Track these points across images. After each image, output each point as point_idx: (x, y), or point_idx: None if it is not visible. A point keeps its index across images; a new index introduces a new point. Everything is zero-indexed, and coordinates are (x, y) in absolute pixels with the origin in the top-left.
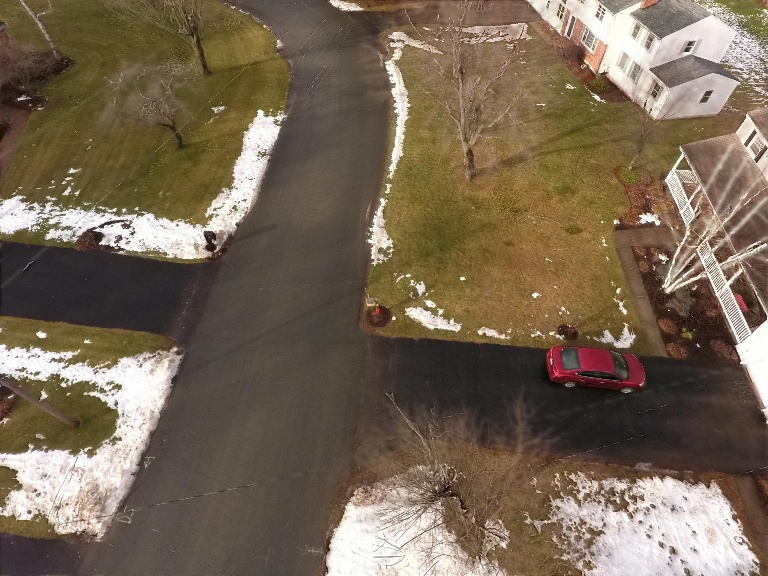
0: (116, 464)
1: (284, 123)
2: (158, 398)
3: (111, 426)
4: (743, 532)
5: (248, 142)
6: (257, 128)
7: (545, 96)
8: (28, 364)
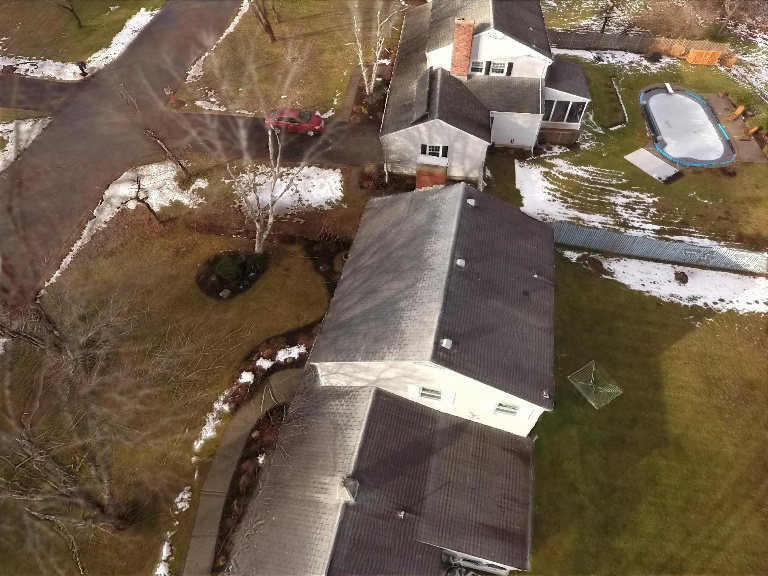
0: (2, 158)
1: (157, 15)
2: (32, 135)
3: (3, 146)
4: (342, 186)
5: (128, 25)
6: (137, 17)
7: (361, 1)
8: None
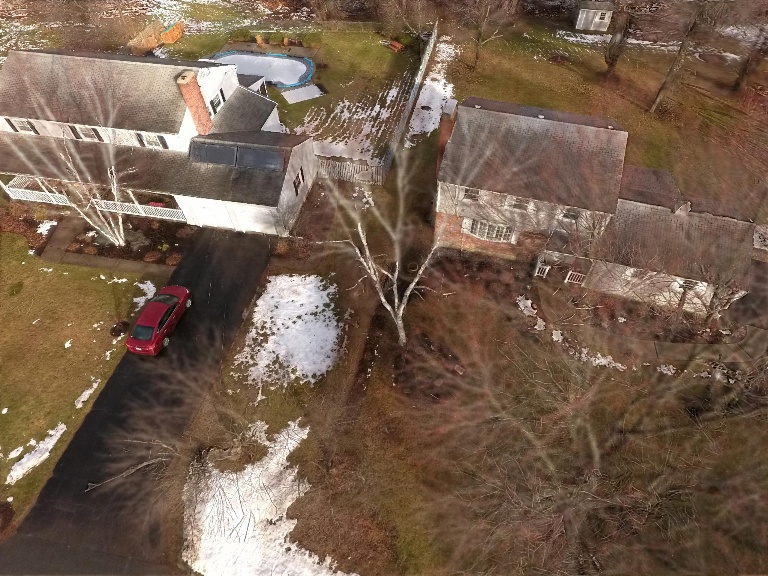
0: None
1: None
2: None
3: None
4: (300, 275)
5: None
6: None
7: None
8: None
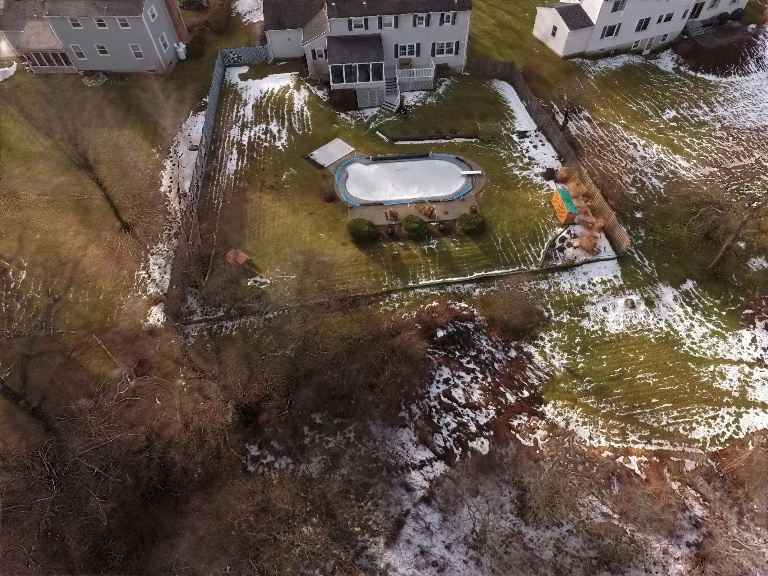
0: None
1: None
2: None
3: None
4: (262, 20)
5: None
6: None
7: None
8: None
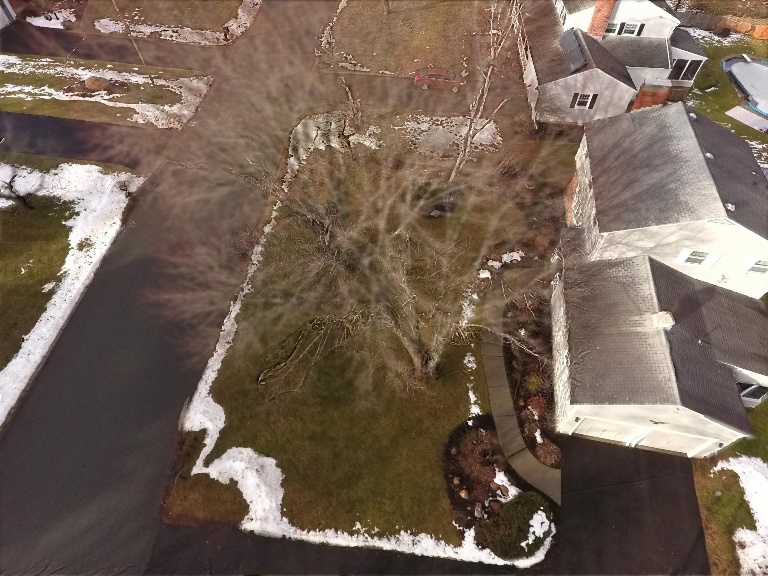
0: (184, 109)
1: None
2: (203, 90)
3: (179, 99)
4: (499, 132)
5: None
6: None
7: None
8: (131, 78)
